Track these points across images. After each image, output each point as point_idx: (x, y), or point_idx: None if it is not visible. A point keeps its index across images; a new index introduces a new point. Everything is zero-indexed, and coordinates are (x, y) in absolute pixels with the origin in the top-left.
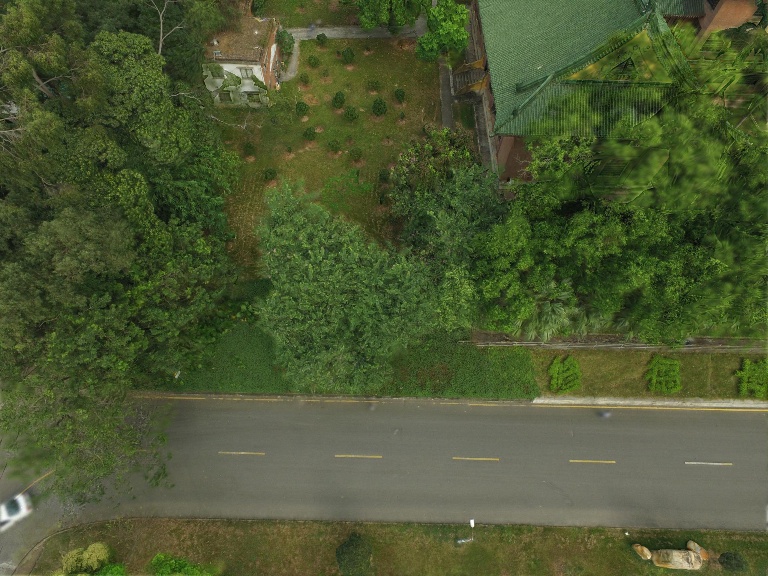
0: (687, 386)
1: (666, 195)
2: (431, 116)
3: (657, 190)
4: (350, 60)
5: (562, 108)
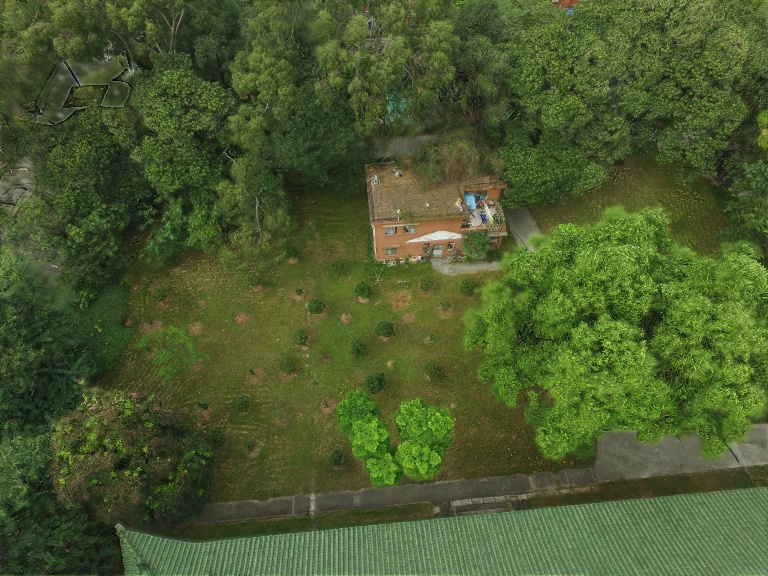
0: None
1: None
2: None
3: None
4: None
5: None
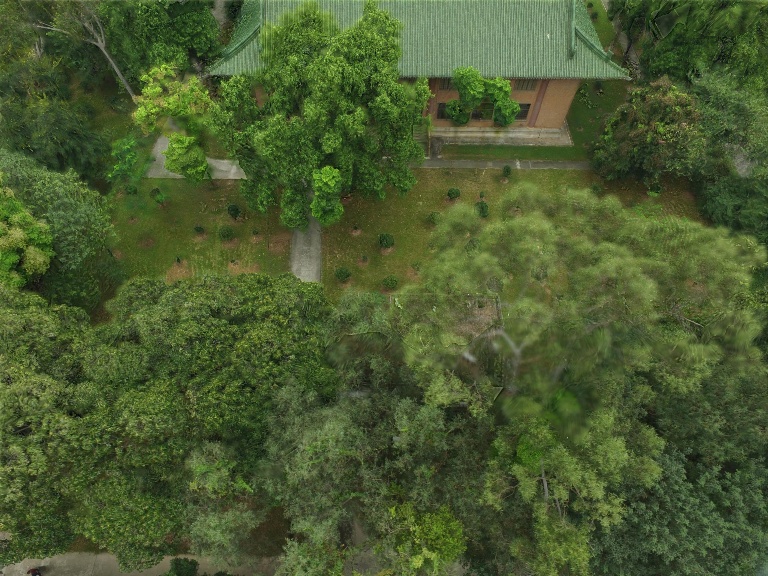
0: None
1: None
2: (469, 176)
3: None
4: (393, 240)
5: None
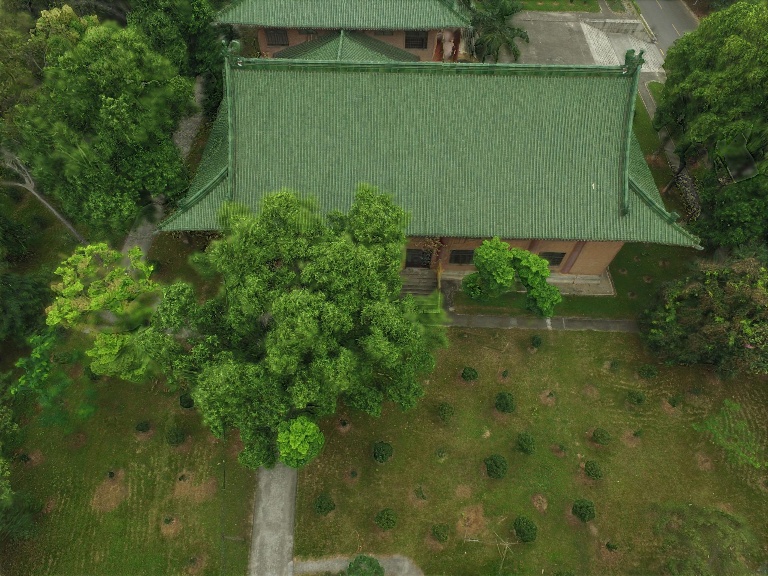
0: None
1: None
2: (488, 340)
3: None
4: (392, 449)
5: (638, 182)
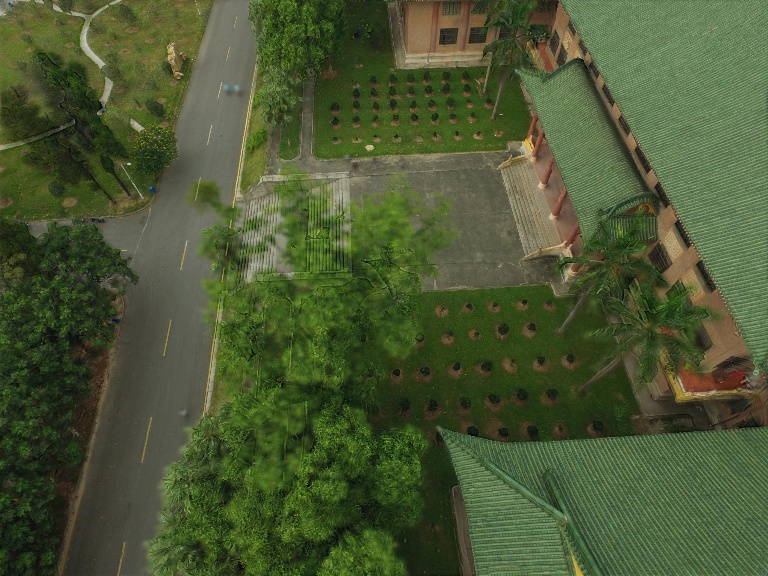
0: (261, 78)
1: None
2: None
3: None
4: None
5: None
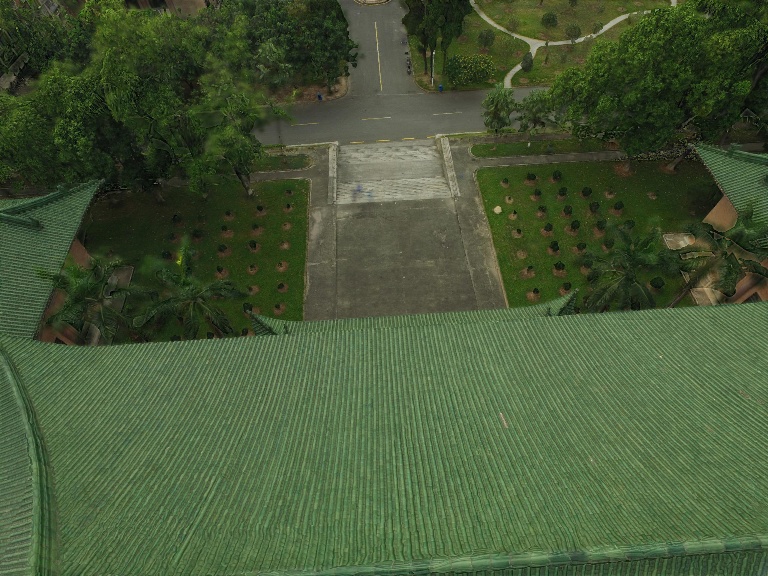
0: None
1: (762, 90)
2: None
3: (767, 97)
4: None
5: None
